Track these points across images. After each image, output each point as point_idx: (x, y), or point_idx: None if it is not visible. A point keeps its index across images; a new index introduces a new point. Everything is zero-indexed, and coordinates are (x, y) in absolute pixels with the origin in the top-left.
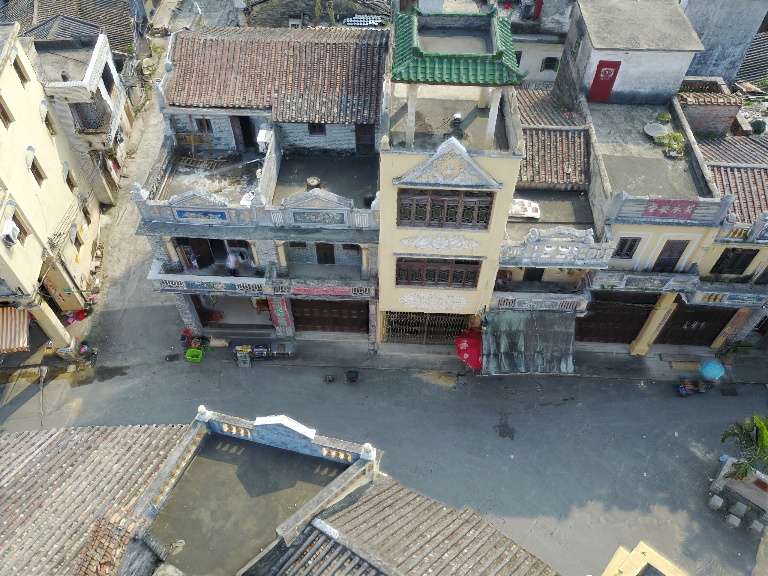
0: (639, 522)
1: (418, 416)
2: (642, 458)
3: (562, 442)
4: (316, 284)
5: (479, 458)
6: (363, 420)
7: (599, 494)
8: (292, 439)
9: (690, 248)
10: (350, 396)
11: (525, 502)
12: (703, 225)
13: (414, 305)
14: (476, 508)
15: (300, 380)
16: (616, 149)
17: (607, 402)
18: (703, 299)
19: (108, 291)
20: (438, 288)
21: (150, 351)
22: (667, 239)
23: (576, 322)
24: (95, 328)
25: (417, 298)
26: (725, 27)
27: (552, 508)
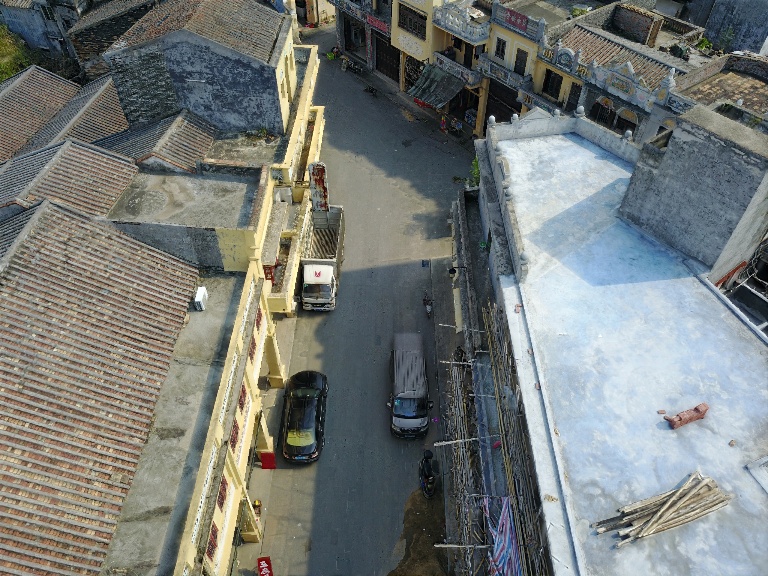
0: (412, 197)
1: (381, 119)
2: (449, 186)
3: (424, 161)
4: (374, 16)
5: (383, 142)
6: (359, 107)
7: (411, 181)
8: (280, 3)
9: (529, 61)
10: (366, 99)
11: (378, 162)
12: (530, 39)
13: (403, 45)
14: (357, 151)
15: (356, 85)
16: (548, 7)
17: (467, 165)
18: (523, 99)
19: (331, 25)
20: (412, 35)
21: (319, 48)
22: (518, 47)
23: None
24: (311, 33)
25: (404, 39)
26: (751, 6)
27: (385, 170)
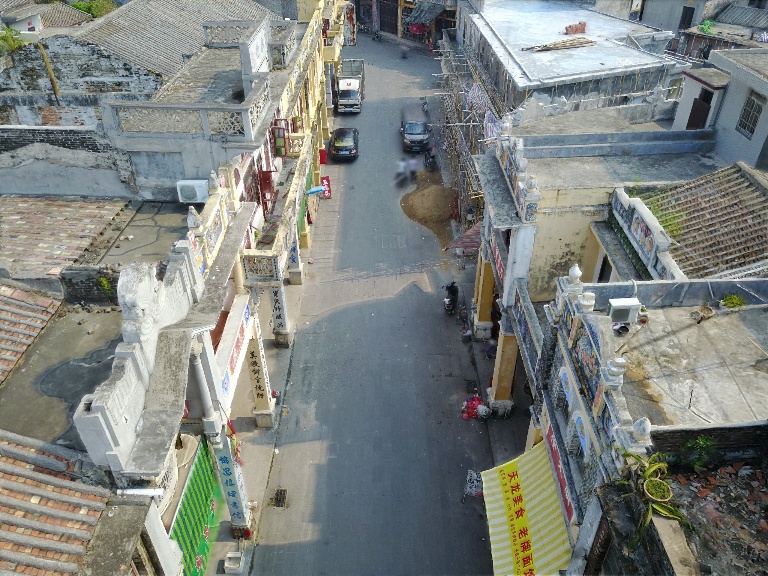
0: (410, 76)
1: None
2: None
3: (418, 63)
4: None
5: None
6: None
7: None
8: None
9: None
10: None
11: None
12: None
13: None
14: (369, 61)
15: (365, 38)
16: None
17: None
18: None
19: None
20: None
21: None
22: None
23: None
24: None
25: None
26: None
27: (390, 67)
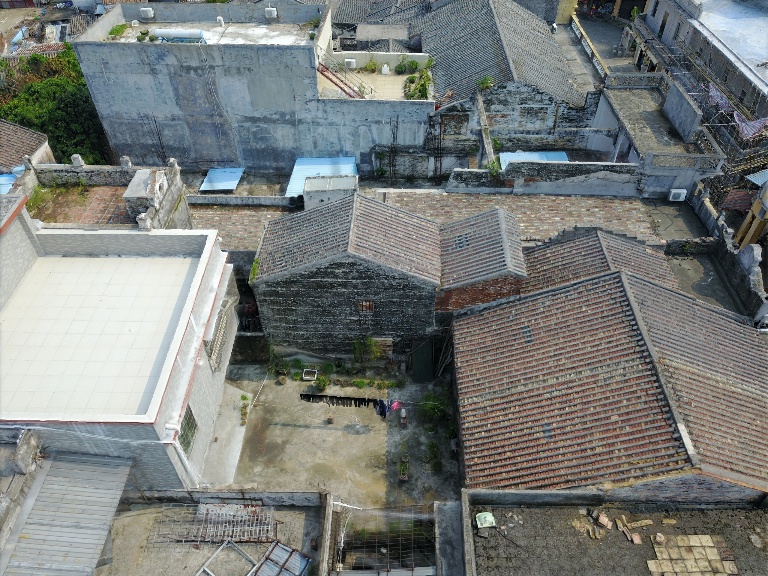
0: None
1: None
2: (606, 39)
3: (586, 29)
4: None
5: None
6: None
7: None
8: None
9: None
10: None
11: None
12: None
13: None
14: None
15: None
16: None
17: (613, 30)
18: None
19: None
20: None
21: None
22: None
23: (623, 4)
24: None
25: None
26: None
27: None
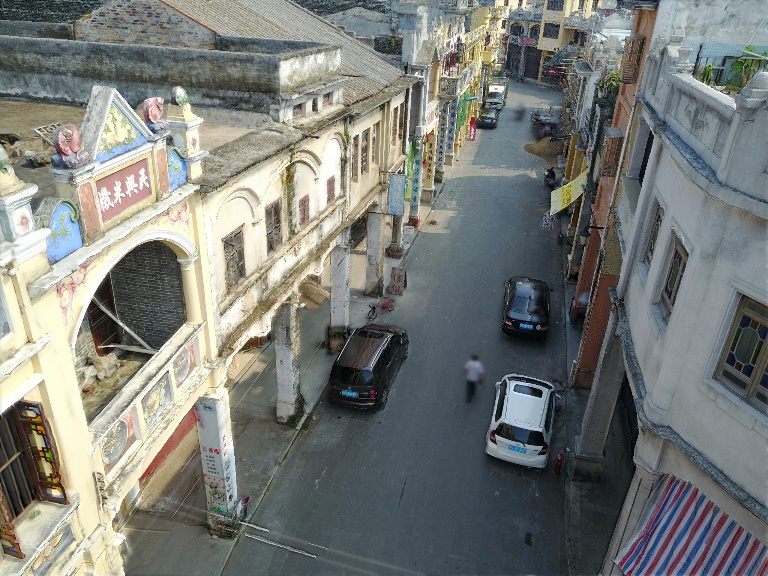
0: (543, 99)
1: (526, 86)
2: None
3: None
4: None
5: None
6: None
7: None
8: None
9: None
10: None
11: None
12: None
13: (544, 46)
14: None
15: (511, 80)
16: None
17: None
18: None
19: None
20: None
21: None
22: None
23: None
24: None
25: None
26: None
27: None
